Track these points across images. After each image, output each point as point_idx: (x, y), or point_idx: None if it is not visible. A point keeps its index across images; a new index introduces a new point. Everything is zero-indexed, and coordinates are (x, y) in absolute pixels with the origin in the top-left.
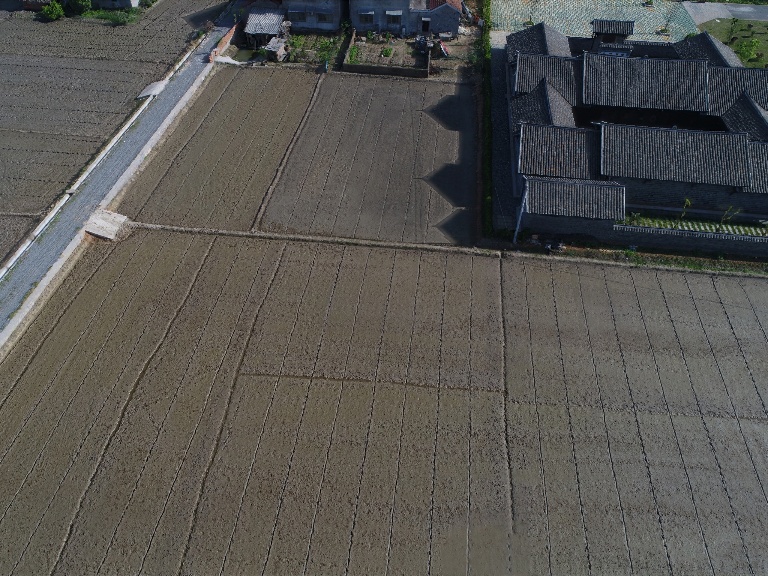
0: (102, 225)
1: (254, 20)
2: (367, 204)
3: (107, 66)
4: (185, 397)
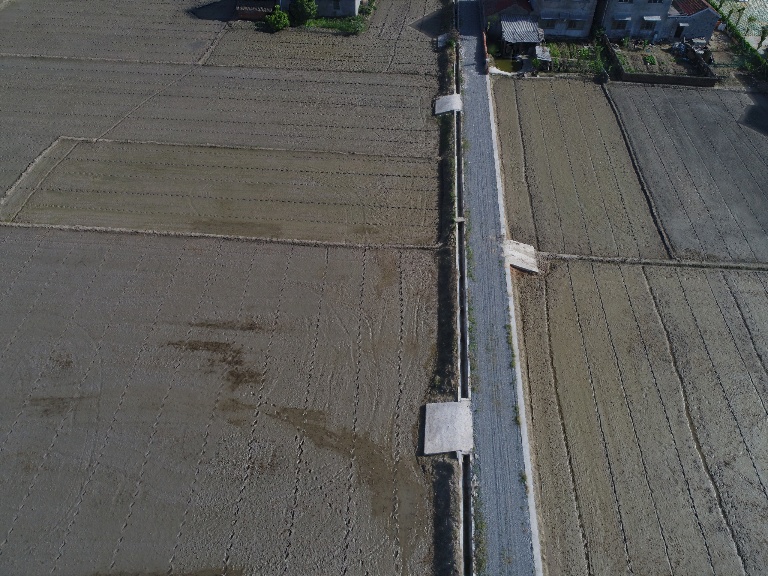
0: (520, 257)
1: (509, 28)
2: (766, 226)
3: (374, 79)
4: (760, 452)
